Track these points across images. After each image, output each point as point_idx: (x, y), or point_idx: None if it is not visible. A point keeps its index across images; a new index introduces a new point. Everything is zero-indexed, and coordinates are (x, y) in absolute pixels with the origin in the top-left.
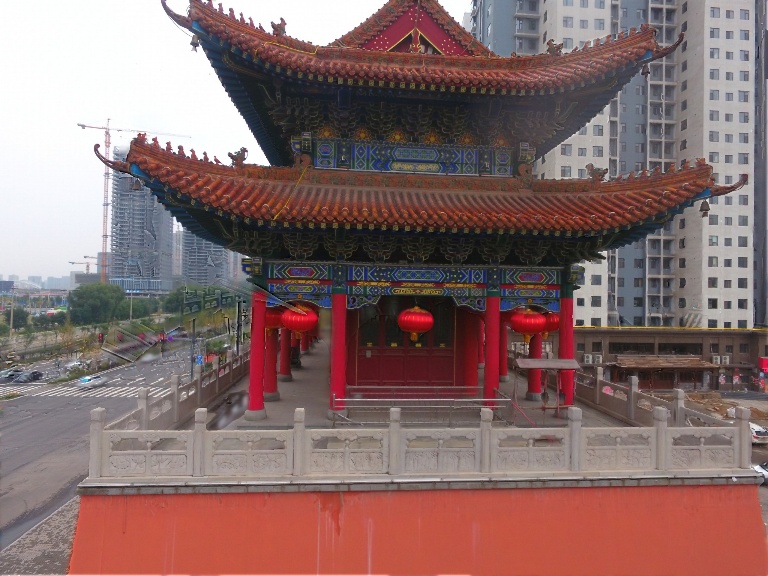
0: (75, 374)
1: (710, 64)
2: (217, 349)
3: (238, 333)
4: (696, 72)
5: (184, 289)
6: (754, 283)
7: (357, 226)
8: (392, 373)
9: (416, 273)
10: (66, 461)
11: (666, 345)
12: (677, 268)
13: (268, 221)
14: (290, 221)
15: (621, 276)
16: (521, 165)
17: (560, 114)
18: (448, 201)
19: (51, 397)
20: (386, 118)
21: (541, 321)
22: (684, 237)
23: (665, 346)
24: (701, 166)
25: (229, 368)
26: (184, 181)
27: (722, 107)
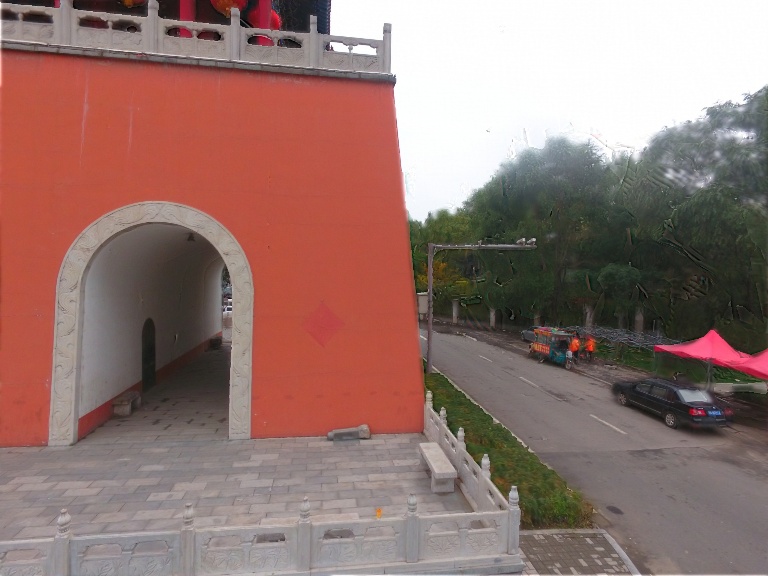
0: None
1: None
2: None
3: None
4: None
5: None
6: None
7: None
8: None
9: None
10: None
11: None
12: None
13: None
14: None
15: None
16: None
17: None
18: None
19: None
20: None
21: None
22: None
23: None
24: None
25: None
26: None
27: None
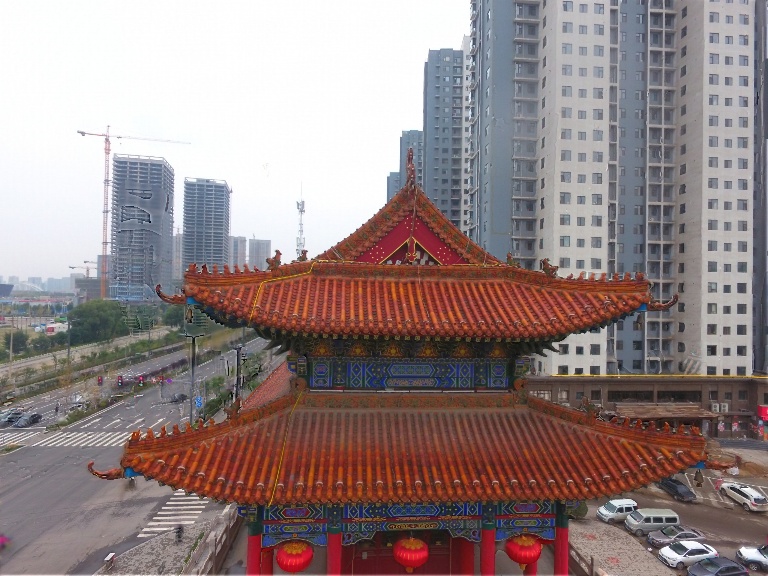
0: (74, 416)
1: (709, 111)
2: (216, 389)
3: (237, 386)
4: (695, 118)
5: (183, 332)
6: (753, 330)
7: (351, 505)
8: (388, 573)
9: (411, 508)
10: (65, 542)
11: (665, 393)
12: (676, 312)
13: (262, 505)
14: (284, 504)
15: (620, 320)
16: (517, 380)
17: (555, 340)
18: (443, 433)
19: (50, 448)
20: (381, 341)
21: (536, 554)
22: (683, 282)
23: (664, 393)
24: (695, 436)
25: (226, 534)
26: (178, 475)
27: (721, 153)
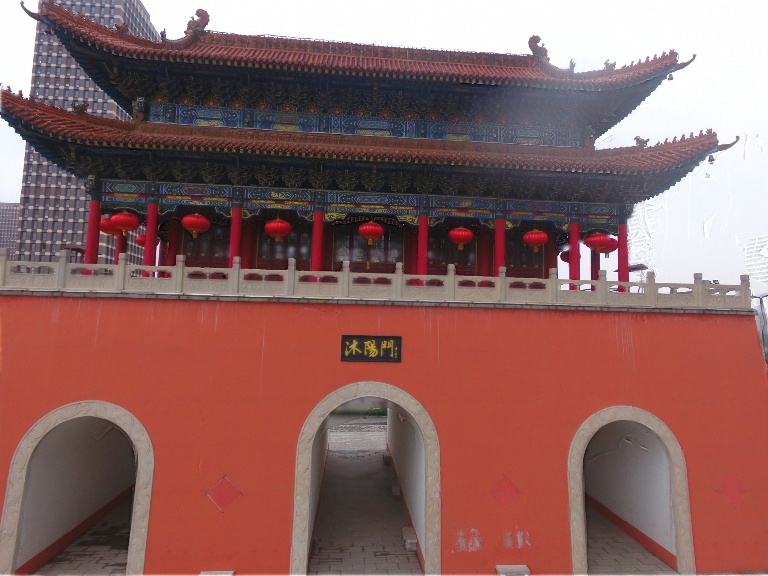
0: None
1: None
2: None
3: None
4: None
5: None
6: None
7: None
8: None
9: None
10: None
11: None
12: None
13: None
14: None
15: None
16: None
17: None
18: None
19: None
20: None
21: None
22: None
23: None
24: None
25: None
26: None
27: None
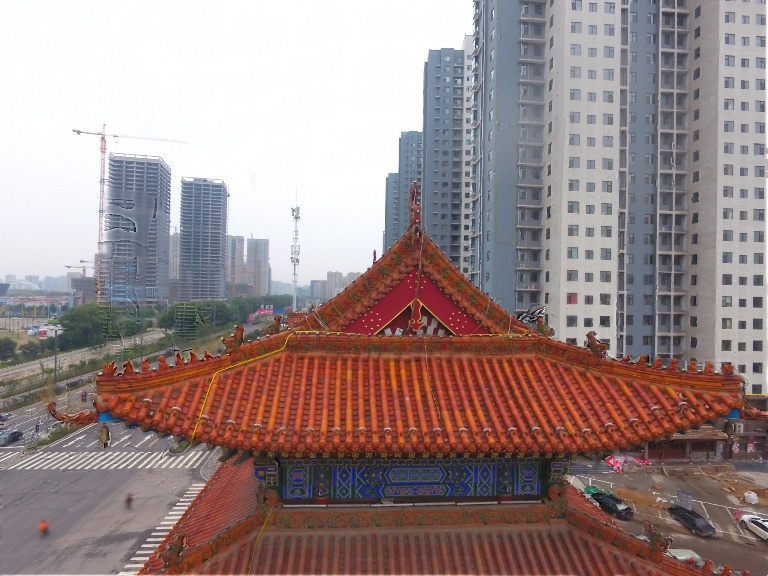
0: (57, 434)
1: (724, 116)
2: None
3: None
4: (709, 123)
5: (171, 346)
6: None
7: None
8: None
9: None
10: None
11: None
12: (688, 326)
13: None
14: None
15: (629, 334)
16: (552, 487)
17: None
18: (459, 569)
19: (28, 471)
20: None
21: None
22: (696, 295)
23: None
24: None
25: None
26: None
27: (737, 161)
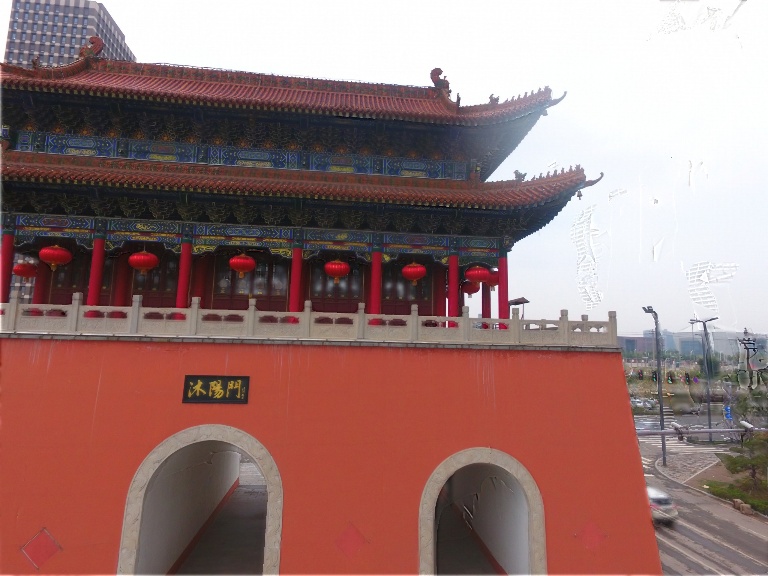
0: None
1: None
2: None
3: (658, 363)
4: None
5: (693, 316)
6: None
7: None
8: None
9: None
10: None
11: None
12: None
13: None
14: None
15: None
16: None
17: None
18: None
19: None
20: None
21: None
22: None
23: None
24: None
25: None
26: None
27: None
